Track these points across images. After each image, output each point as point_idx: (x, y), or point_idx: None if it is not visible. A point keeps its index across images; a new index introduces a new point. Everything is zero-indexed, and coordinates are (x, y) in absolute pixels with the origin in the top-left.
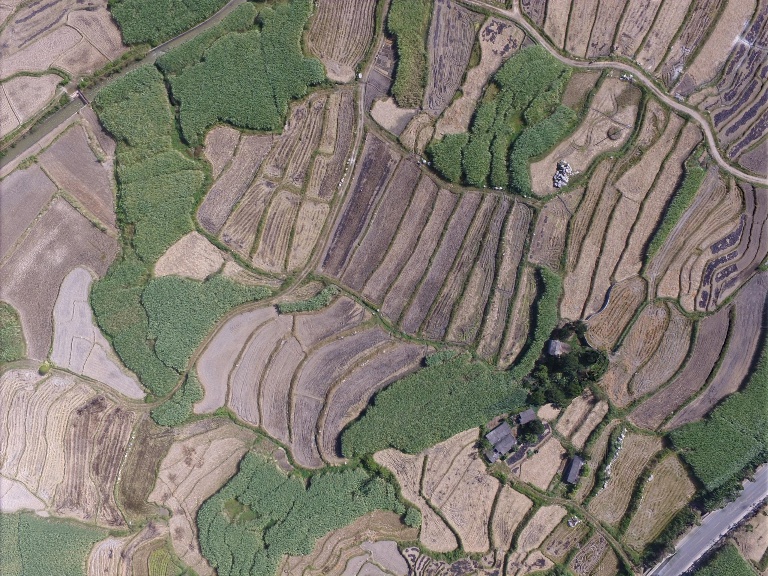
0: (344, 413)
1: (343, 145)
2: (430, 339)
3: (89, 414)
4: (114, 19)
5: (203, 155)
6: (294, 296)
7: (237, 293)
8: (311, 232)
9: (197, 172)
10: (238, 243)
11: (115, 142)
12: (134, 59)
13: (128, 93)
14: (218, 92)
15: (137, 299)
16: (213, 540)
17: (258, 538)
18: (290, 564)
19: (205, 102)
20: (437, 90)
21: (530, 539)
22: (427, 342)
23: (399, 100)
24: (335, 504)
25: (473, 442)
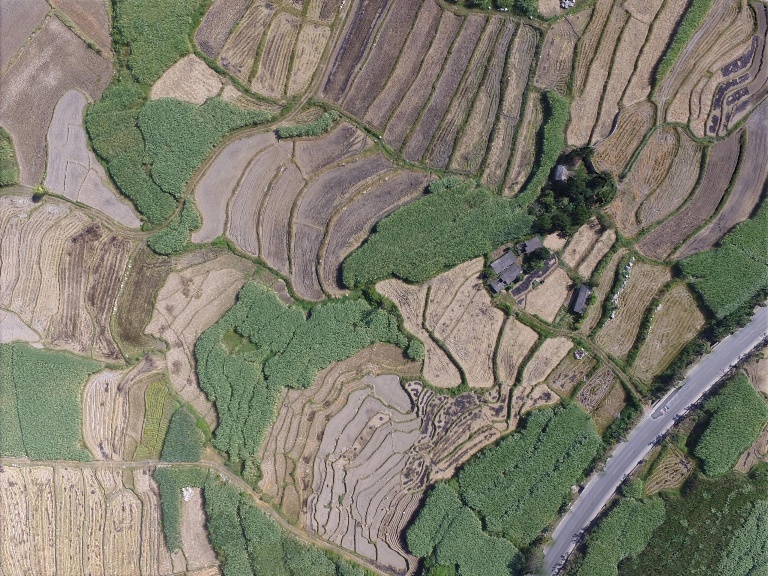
0: (345, 243)
1: None
2: (433, 167)
3: (84, 242)
4: None
5: None
6: (294, 122)
7: (236, 116)
8: (311, 56)
9: None
10: (237, 67)
11: None
12: None
13: None
14: None
15: (133, 122)
16: (211, 371)
17: (257, 370)
18: (290, 398)
19: None
20: None
21: (535, 372)
22: (430, 170)
23: None
24: (336, 335)
25: (477, 272)
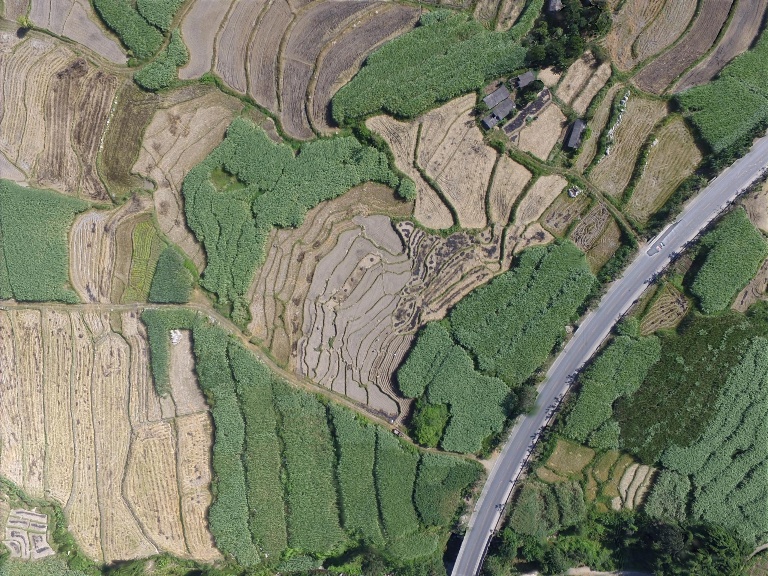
0: (335, 79)
1: None
2: (425, 2)
3: (70, 78)
4: None
5: None
6: None
7: None
8: None
9: None
10: None
11: None
12: None
13: None
14: None
15: None
16: (199, 208)
17: (246, 209)
18: (279, 239)
19: None
20: None
21: (529, 211)
22: (422, 4)
23: None
24: (326, 172)
25: (470, 109)
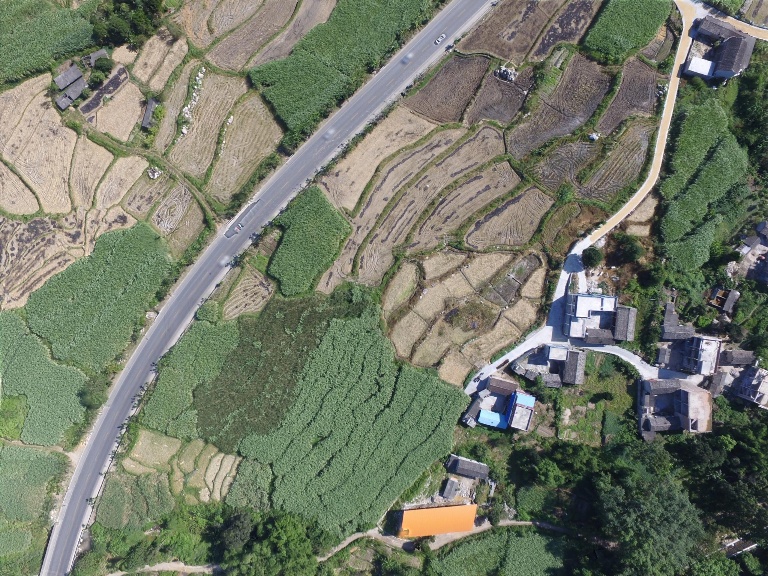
0: None
1: None
2: None
3: None
4: None
5: None
6: None
7: None
8: None
9: None
10: None
11: None
12: None
13: None
14: None
15: None
16: None
17: None
18: None
19: None
20: None
21: (110, 194)
22: None
23: None
24: None
25: (45, 90)
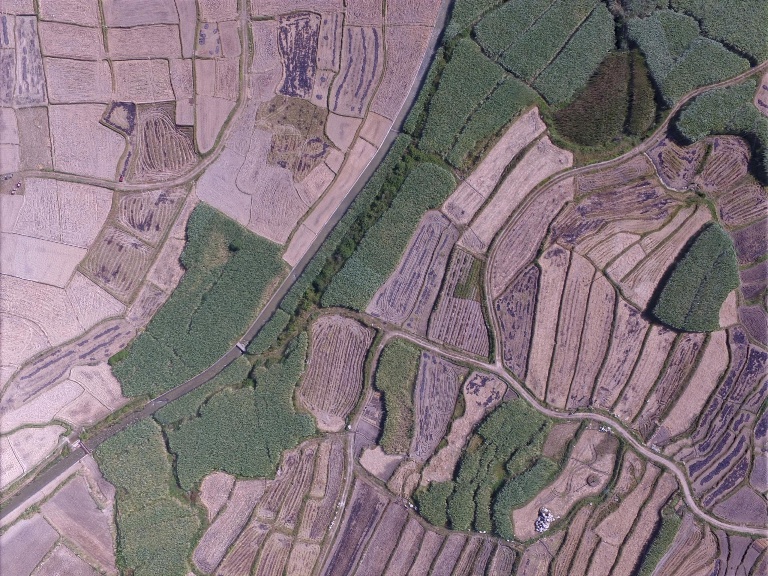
0: None
1: (333, 489)
2: None
3: None
4: (115, 376)
5: (199, 500)
6: None
7: None
8: (302, 571)
9: (193, 518)
10: None
11: (115, 487)
12: (133, 411)
13: (128, 446)
14: (214, 446)
15: None
16: None
17: None
18: None
19: (201, 456)
20: (423, 438)
21: None
22: None
23: (387, 450)
24: None
25: None
